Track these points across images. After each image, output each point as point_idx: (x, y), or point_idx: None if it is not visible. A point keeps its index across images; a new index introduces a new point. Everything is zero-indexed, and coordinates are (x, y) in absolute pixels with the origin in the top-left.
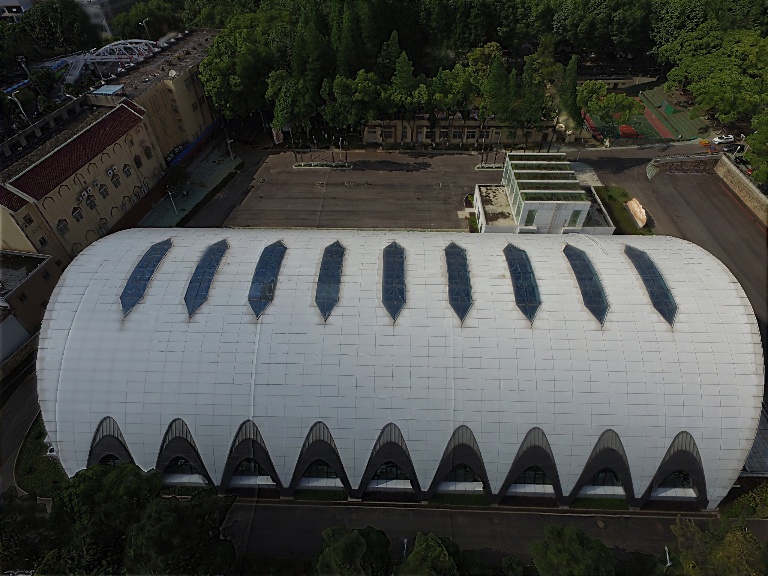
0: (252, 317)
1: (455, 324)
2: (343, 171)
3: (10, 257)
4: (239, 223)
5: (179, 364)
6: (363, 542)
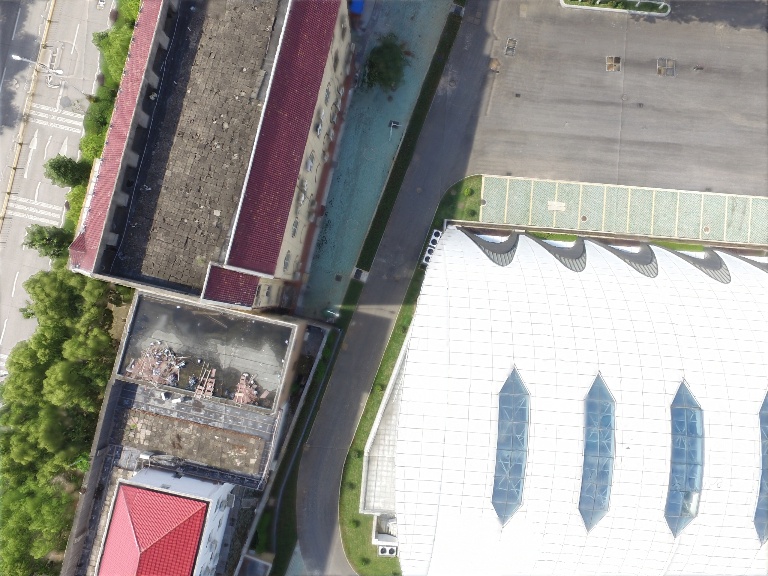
0: (668, 537)
1: None
2: (652, 22)
3: (234, 321)
4: (493, 166)
5: (571, 572)
6: None
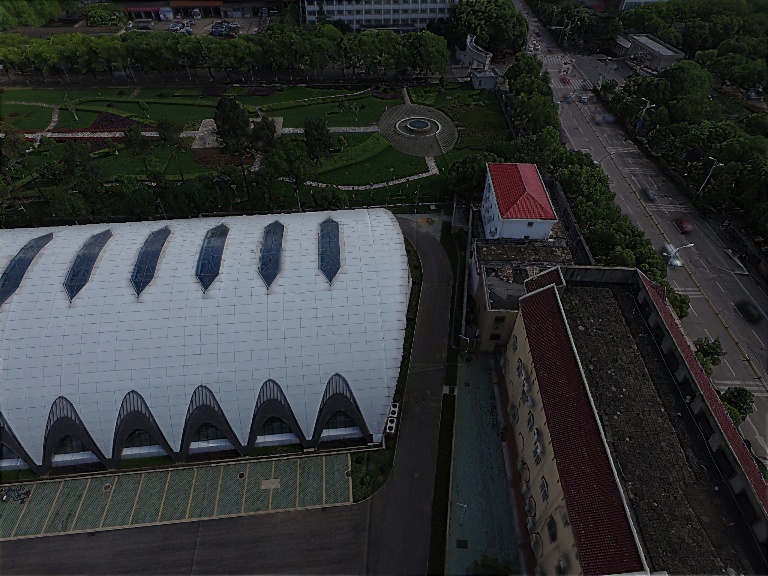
0: None
1: (59, 232)
2: None
3: None
4: (342, 515)
5: None
6: (156, 128)
